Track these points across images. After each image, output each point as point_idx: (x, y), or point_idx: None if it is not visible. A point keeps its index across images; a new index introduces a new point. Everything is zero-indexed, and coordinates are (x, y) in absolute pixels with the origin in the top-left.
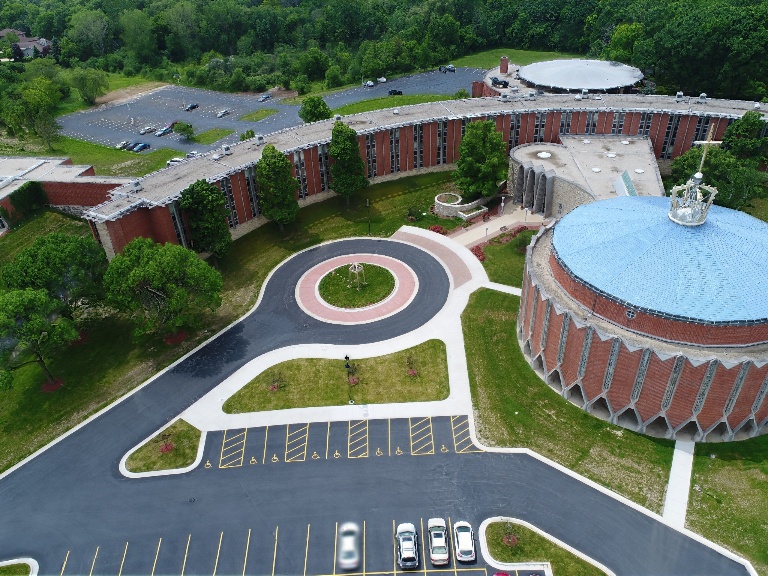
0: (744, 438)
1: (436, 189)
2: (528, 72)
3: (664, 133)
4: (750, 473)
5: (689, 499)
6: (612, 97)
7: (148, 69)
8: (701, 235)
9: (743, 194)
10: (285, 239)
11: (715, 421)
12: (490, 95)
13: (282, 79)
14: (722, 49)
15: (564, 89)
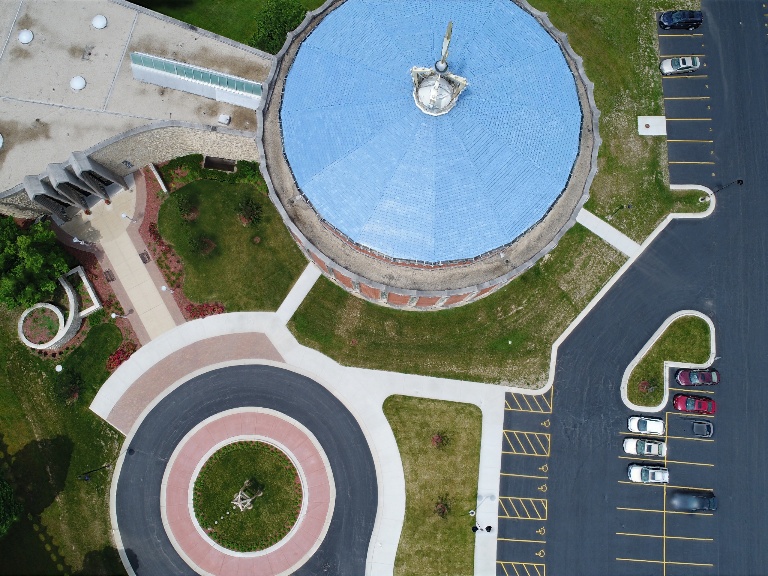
0: None
1: None
2: None
3: None
4: None
5: (618, 229)
6: None
7: None
8: (471, 98)
9: None
10: None
11: None
12: None
13: None
14: None
15: None
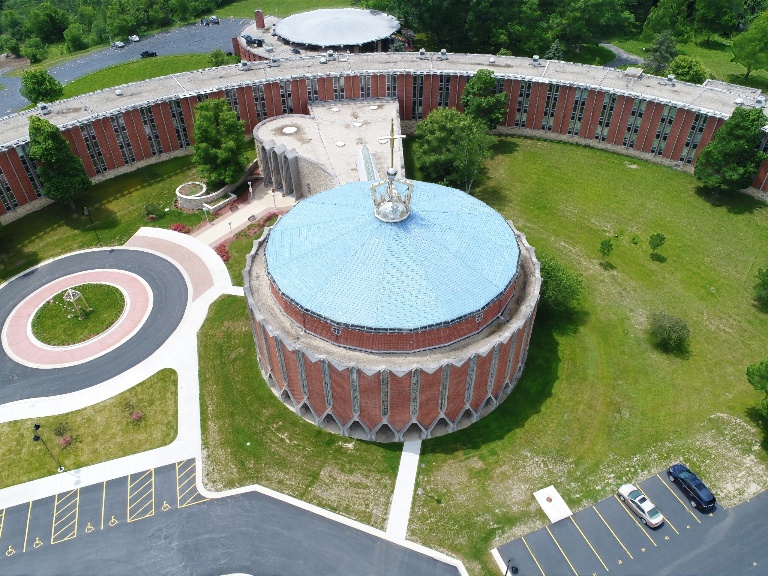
0: (467, 425)
1: (181, 177)
2: (286, 26)
3: (411, 94)
4: (469, 463)
5: (412, 506)
6: (358, 57)
7: None
8: (404, 232)
9: (478, 157)
10: None
11: (435, 418)
12: (245, 56)
13: (7, 45)
14: None
15: (320, 46)
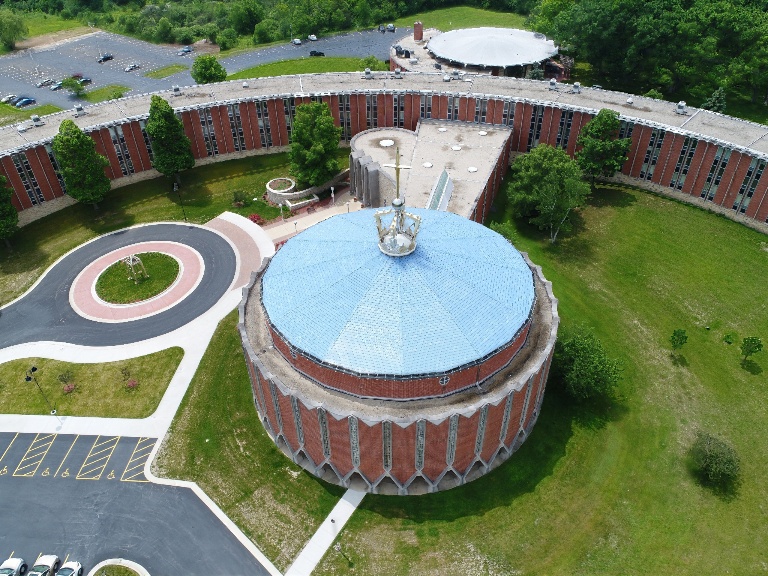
0: (421, 493)
1: (280, 171)
2: (442, 40)
3: (529, 125)
4: (403, 535)
5: (322, 559)
6: (485, 80)
7: (86, 12)
8: (399, 268)
9: (568, 205)
10: (96, 219)
11: (380, 474)
12: (391, 65)
13: (207, 32)
14: (629, 29)
15: (463, 64)
